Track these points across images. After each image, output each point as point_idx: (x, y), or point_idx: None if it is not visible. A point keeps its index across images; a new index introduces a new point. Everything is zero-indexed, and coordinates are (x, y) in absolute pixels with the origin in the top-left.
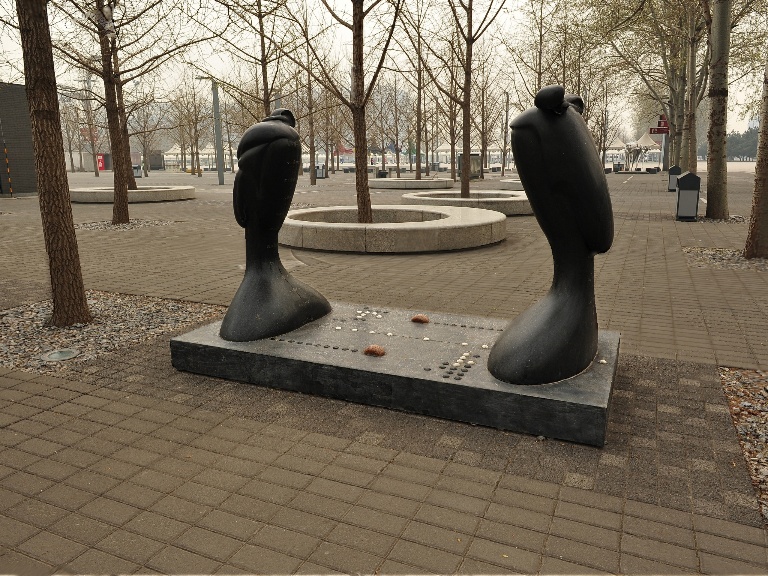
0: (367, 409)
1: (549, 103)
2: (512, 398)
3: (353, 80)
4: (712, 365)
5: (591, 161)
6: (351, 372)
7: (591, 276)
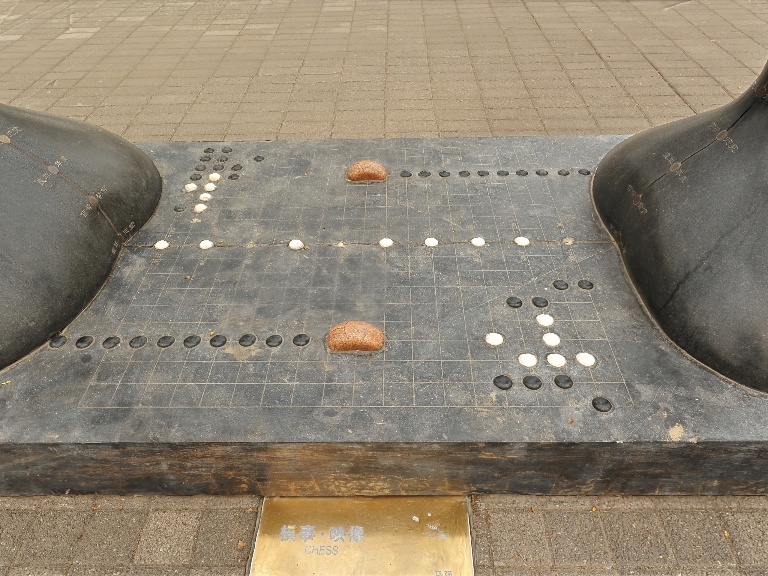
0: None
1: None
2: None
3: None
4: None
5: None
6: None
7: None
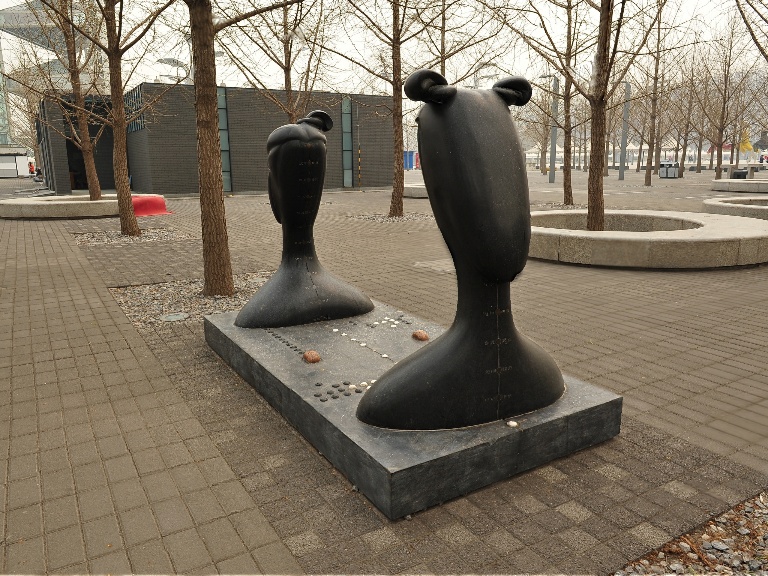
0: (270, 411)
1: (413, 91)
2: (337, 433)
3: (595, 69)
4: None
5: (473, 162)
6: (265, 371)
7: (491, 310)
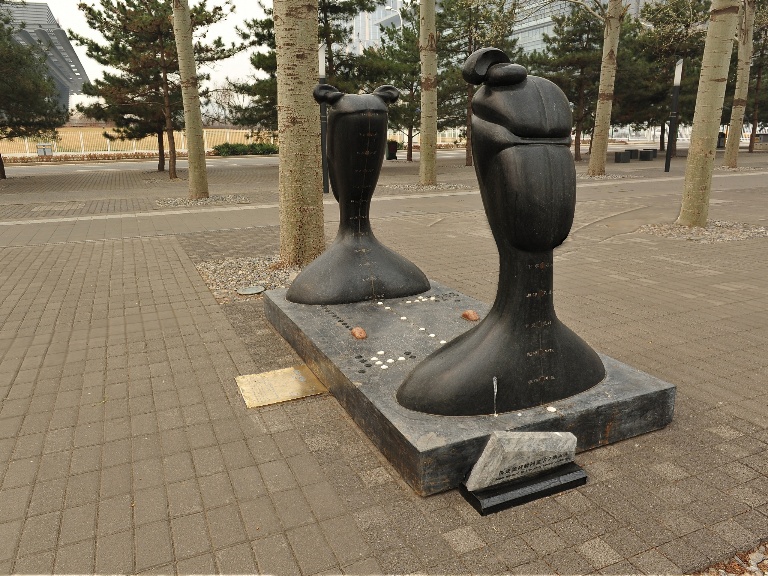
0: None
1: None
2: None
3: None
4: (224, 304)
5: None
6: None
7: None
